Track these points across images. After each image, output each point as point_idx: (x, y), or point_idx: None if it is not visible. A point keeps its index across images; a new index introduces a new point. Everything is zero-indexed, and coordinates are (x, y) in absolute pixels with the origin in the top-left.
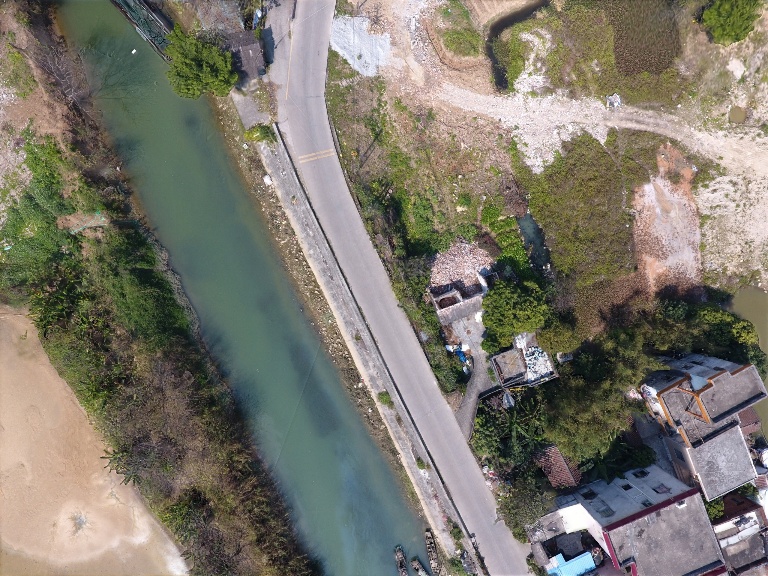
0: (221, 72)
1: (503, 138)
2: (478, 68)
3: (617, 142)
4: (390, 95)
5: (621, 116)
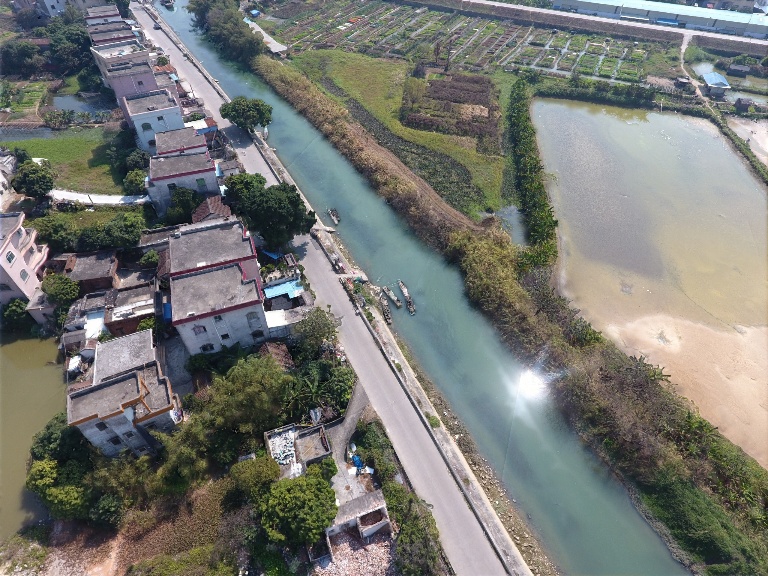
0: None
1: None
2: None
3: None
4: None
5: None
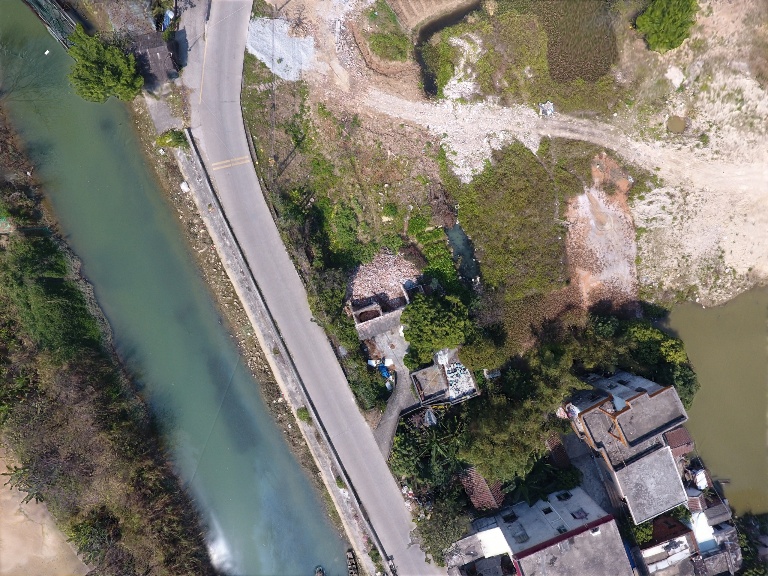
0: (124, 75)
1: (432, 146)
2: (406, 73)
3: (550, 151)
4: (313, 100)
5: (554, 124)
